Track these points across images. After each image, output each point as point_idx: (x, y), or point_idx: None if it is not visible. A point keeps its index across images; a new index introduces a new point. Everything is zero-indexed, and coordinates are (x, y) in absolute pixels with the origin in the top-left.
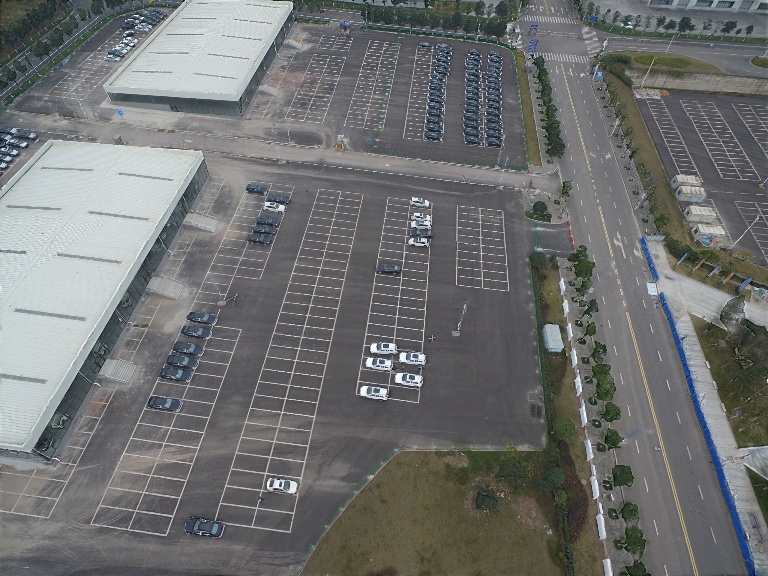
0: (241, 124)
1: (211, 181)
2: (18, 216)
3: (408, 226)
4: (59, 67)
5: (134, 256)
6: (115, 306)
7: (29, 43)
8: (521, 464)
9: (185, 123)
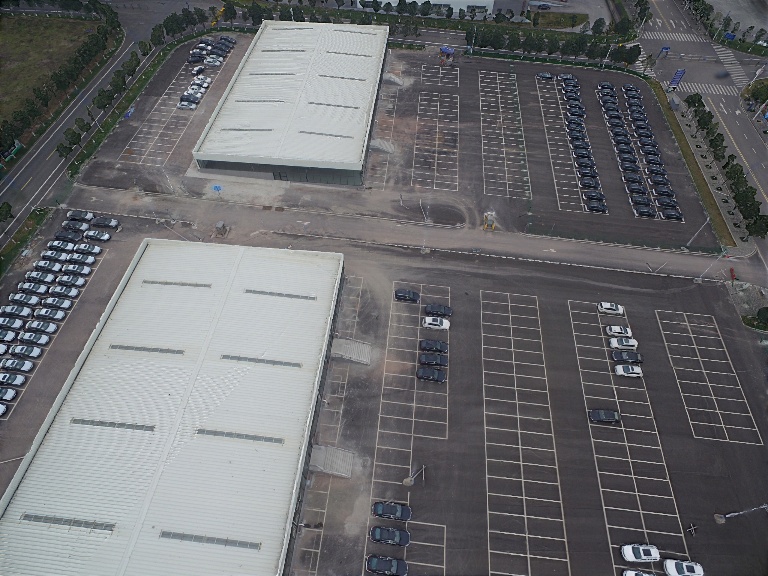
0: (361, 196)
1: (347, 284)
2: (130, 364)
3: (606, 344)
4: (125, 119)
5: (298, 429)
6: (292, 518)
7: (81, 85)
8: None
9: (294, 196)
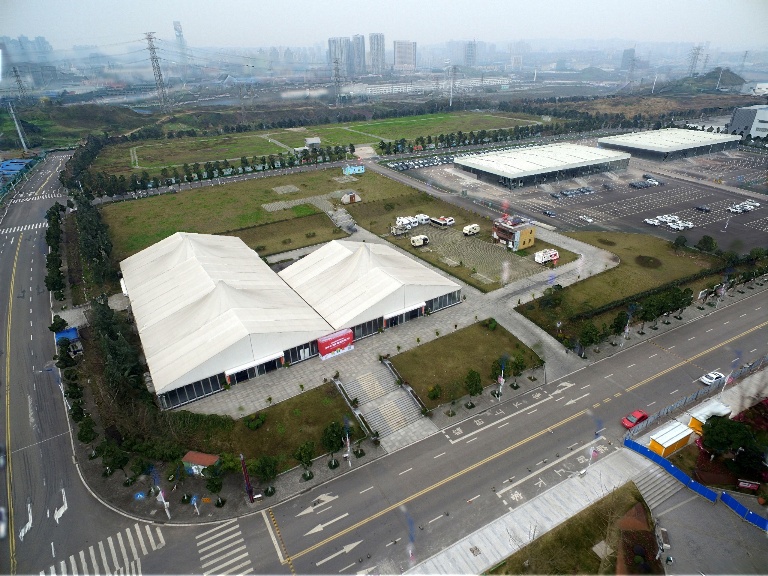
0: (660, 165)
1: (626, 172)
2: (539, 151)
3: None
4: (581, 138)
5: None
6: (560, 169)
7: (572, 132)
8: (712, 239)
9: None
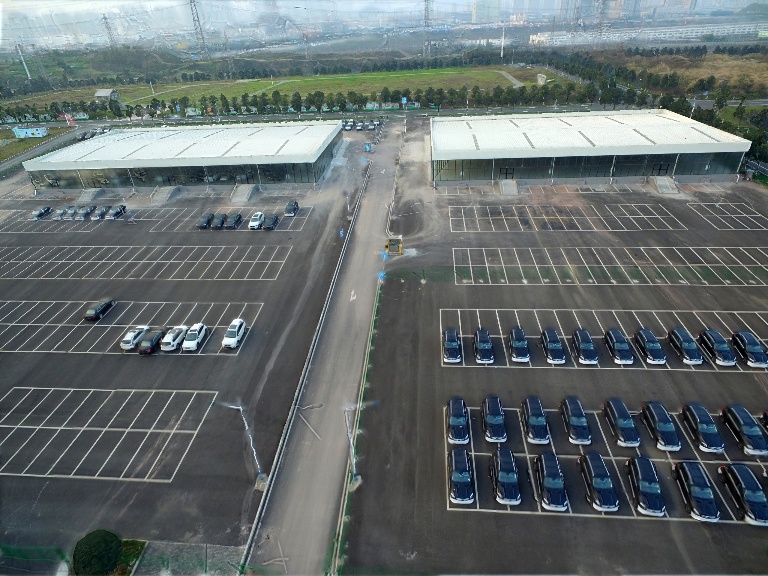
0: (423, 186)
1: (312, 189)
2: (249, 131)
3: None
4: None
5: None
6: (127, 166)
7: None
8: None
9: (413, 164)
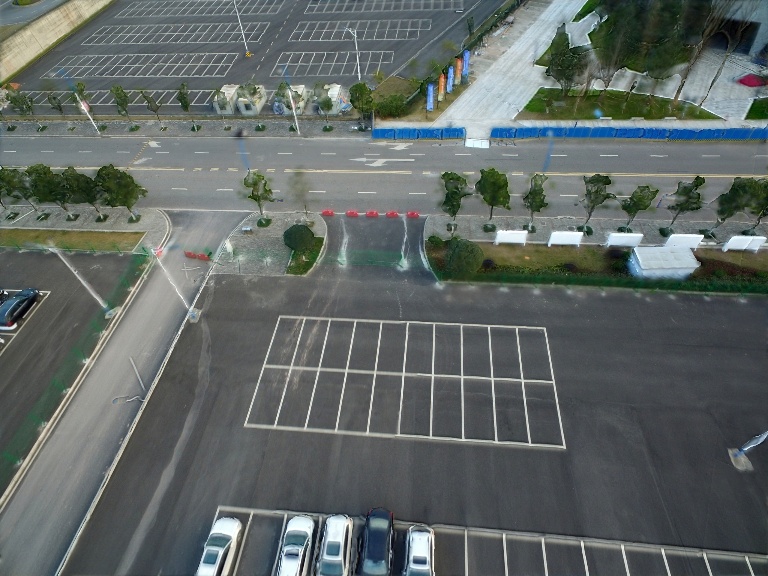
0: None
1: None
2: None
3: None
4: None
5: None
6: None
7: None
8: None
9: None
